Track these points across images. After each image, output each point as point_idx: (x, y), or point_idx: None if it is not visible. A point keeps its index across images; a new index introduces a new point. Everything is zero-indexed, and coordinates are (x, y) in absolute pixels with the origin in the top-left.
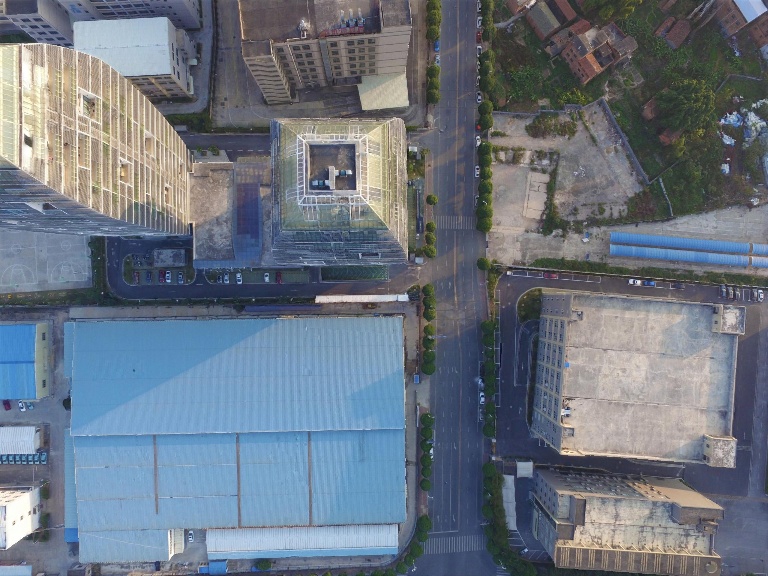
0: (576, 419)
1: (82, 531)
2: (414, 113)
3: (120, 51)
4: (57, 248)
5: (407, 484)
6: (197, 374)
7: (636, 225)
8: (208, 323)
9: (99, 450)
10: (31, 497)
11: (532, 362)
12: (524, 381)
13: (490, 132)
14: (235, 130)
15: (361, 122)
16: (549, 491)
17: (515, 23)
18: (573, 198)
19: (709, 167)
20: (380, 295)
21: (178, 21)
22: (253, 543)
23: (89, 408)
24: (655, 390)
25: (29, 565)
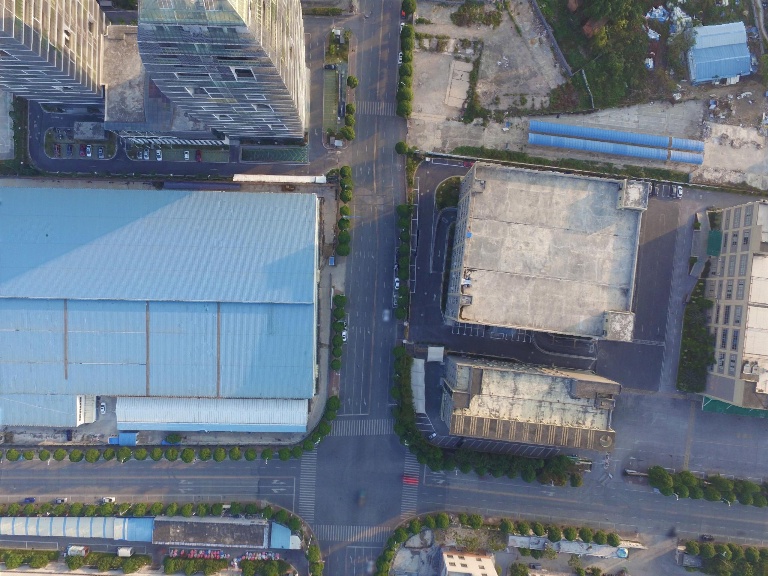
0: (477, 290)
1: None
2: None
3: None
4: None
5: (319, 366)
6: (109, 241)
7: (557, 116)
8: (123, 192)
9: (10, 313)
10: None
11: (448, 249)
12: (440, 268)
13: (415, 19)
14: None
15: None
16: (453, 368)
17: None
18: (495, 88)
19: (632, 61)
20: (298, 176)
21: None
22: (162, 415)
23: (1, 270)
24: (557, 265)
25: None
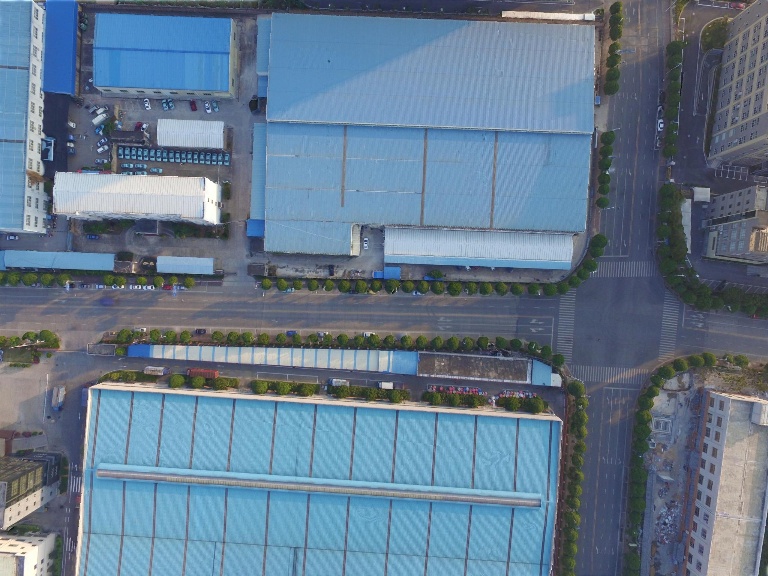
0: None
1: (269, 219)
2: None
3: None
4: None
5: None
6: (390, 68)
7: None
8: (402, 21)
9: (291, 138)
10: (217, 190)
11: (714, 90)
12: (703, 111)
13: None
14: None
15: None
16: (738, 197)
17: None
18: None
19: None
20: (566, 13)
21: None
22: (430, 248)
23: (284, 94)
24: None
25: (211, 258)
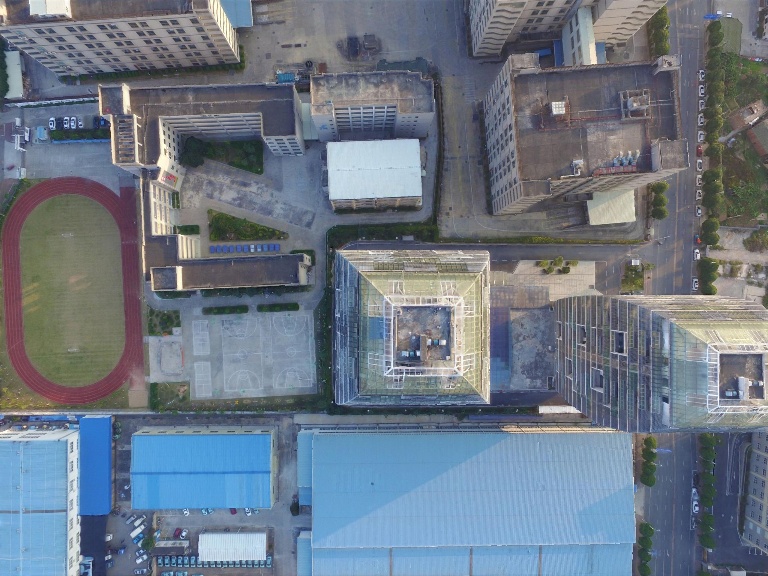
0: None
1: None
2: (634, 225)
3: (373, 173)
4: (283, 354)
5: None
6: (434, 488)
7: None
8: (443, 437)
9: (336, 561)
10: None
11: (746, 473)
12: (736, 490)
13: (709, 246)
14: (461, 241)
15: (750, 322)
16: None
17: (735, 138)
18: None
19: None
20: None
21: (410, 133)
22: None
23: (329, 521)
24: None
25: None
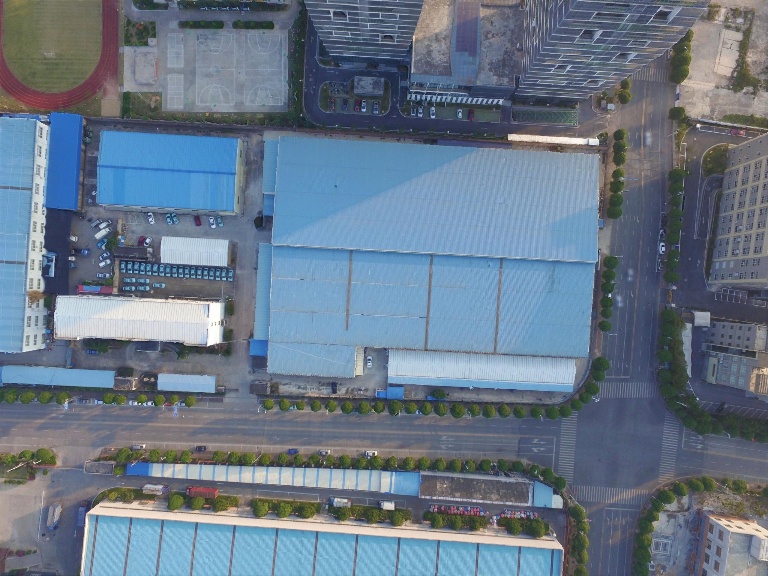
0: None
1: (273, 341)
2: None
3: None
4: (255, 71)
5: None
6: (397, 194)
7: None
8: (409, 146)
9: (296, 262)
10: (220, 308)
11: (715, 215)
12: (704, 235)
13: None
14: None
15: None
16: (738, 330)
17: None
18: (765, 57)
19: None
20: (571, 138)
21: None
22: (434, 369)
23: (291, 219)
24: None
25: (213, 376)
